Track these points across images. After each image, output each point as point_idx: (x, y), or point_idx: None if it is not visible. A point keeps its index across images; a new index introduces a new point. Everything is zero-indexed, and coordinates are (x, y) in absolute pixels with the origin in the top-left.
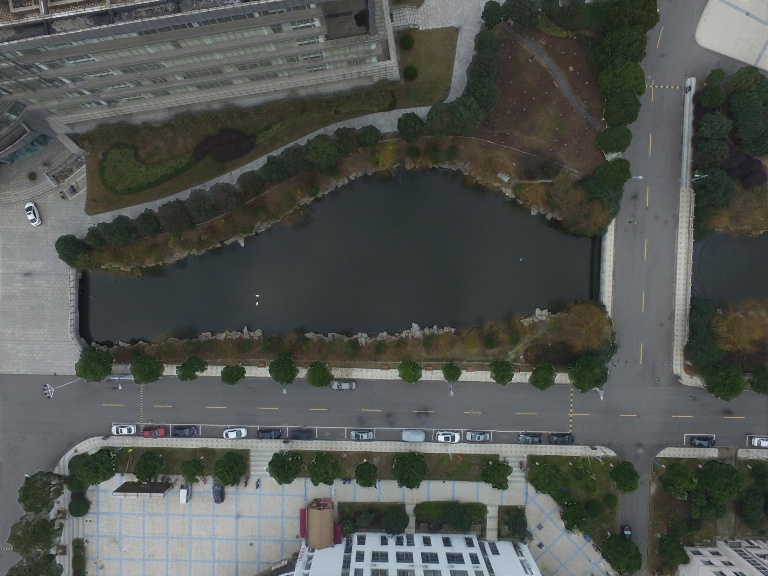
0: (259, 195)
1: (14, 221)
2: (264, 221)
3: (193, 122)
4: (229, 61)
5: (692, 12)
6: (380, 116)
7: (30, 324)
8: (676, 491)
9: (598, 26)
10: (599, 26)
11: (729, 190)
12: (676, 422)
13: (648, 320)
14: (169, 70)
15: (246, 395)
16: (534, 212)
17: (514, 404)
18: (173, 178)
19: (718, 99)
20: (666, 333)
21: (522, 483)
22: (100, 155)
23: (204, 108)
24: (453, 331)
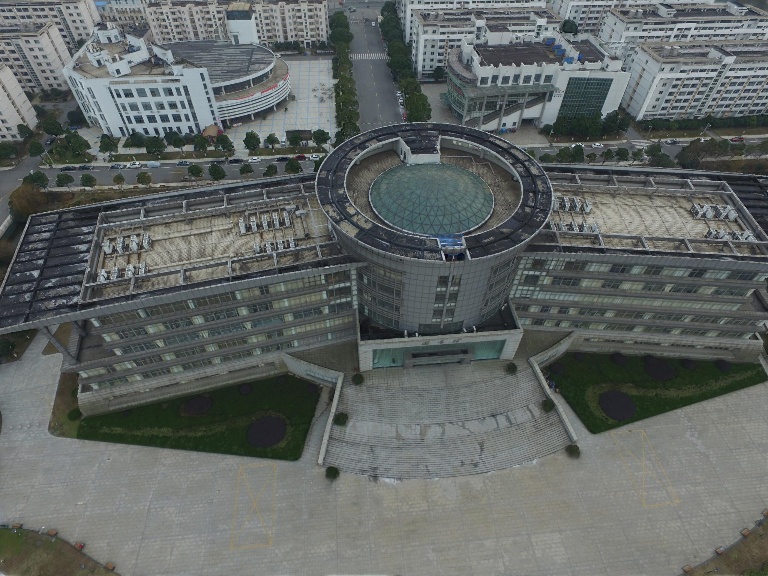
0: None
1: None
2: None
3: None
4: None
5: None
6: None
7: None
8: (12, 155)
9: None
10: None
11: None
12: None
13: None
14: None
15: None
16: None
17: None
18: None
19: None
20: None
21: (99, 155)
22: None
23: None
24: None
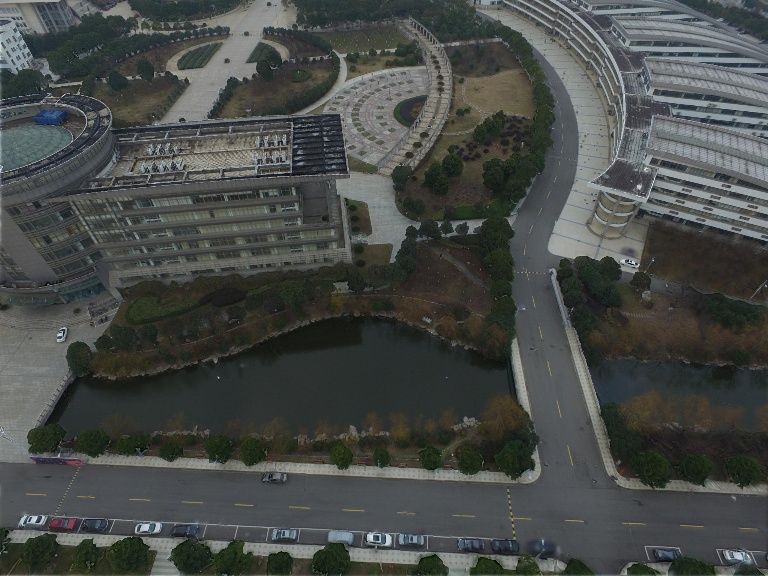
0: (239, 325)
1: (44, 340)
2: (238, 346)
3: (207, 281)
4: (241, 232)
5: (542, 240)
6: (338, 284)
7: (6, 415)
8: None
9: (479, 238)
10: (480, 238)
11: (596, 320)
12: (629, 530)
13: (568, 424)
14: (203, 235)
15: (175, 488)
16: (454, 344)
17: (449, 505)
18: (179, 315)
19: (568, 270)
20: (588, 437)
21: None
22: (133, 302)
23: (217, 275)
24: (388, 434)
